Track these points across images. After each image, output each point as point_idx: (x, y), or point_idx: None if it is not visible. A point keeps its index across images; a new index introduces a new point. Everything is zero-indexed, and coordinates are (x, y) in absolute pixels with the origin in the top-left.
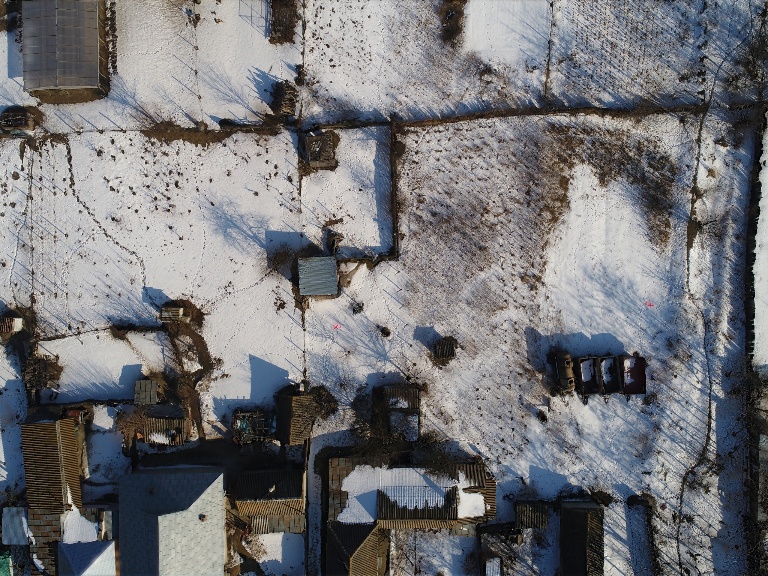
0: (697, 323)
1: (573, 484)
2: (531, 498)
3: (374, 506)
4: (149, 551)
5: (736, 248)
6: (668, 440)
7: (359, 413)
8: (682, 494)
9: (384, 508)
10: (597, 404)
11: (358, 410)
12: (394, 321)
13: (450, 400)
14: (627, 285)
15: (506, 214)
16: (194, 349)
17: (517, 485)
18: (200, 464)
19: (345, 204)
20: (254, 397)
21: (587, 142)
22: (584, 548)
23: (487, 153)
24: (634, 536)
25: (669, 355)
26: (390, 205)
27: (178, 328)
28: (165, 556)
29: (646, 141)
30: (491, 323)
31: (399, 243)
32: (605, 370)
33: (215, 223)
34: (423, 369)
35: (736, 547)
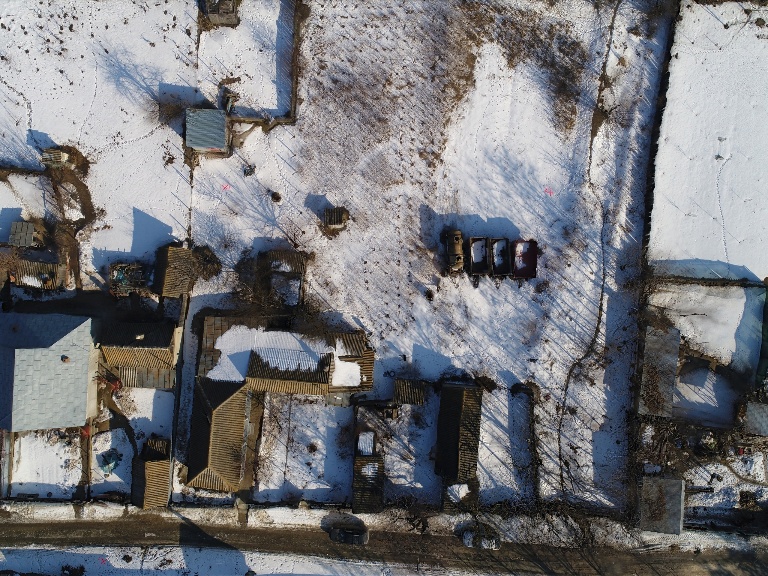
0: (595, 213)
1: (457, 367)
2: (413, 377)
3: (246, 365)
4: (5, 386)
5: (641, 140)
6: (557, 329)
7: (242, 276)
8: (567, 386)
9: (255, 367)
10: (488, 288)
11: (241, 273)
12: (286, 187)
13: (337, 271)
14: (528, 170)
15: (409, 87)
16: (77, 197)
17: (399, 363)
18: (75, 315)
19: (244, 63)
20: (135, 250)
21: (497, 20)
22: (458, 425)
23: (394, 23)
24: (515, 424)
25: (564, 244)
26: (290, 68)
27: (62, 175)
28: (20, 391)
29: (558, 25)
30: (385, 197)
31: (297, 108)
32: (497, 252)
33: (108, 71)
34: (312, 238)
35: (617, 442)
